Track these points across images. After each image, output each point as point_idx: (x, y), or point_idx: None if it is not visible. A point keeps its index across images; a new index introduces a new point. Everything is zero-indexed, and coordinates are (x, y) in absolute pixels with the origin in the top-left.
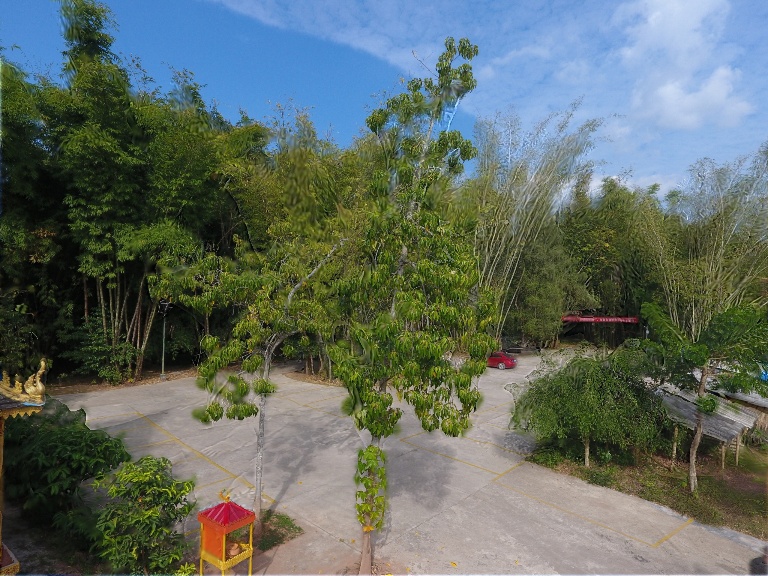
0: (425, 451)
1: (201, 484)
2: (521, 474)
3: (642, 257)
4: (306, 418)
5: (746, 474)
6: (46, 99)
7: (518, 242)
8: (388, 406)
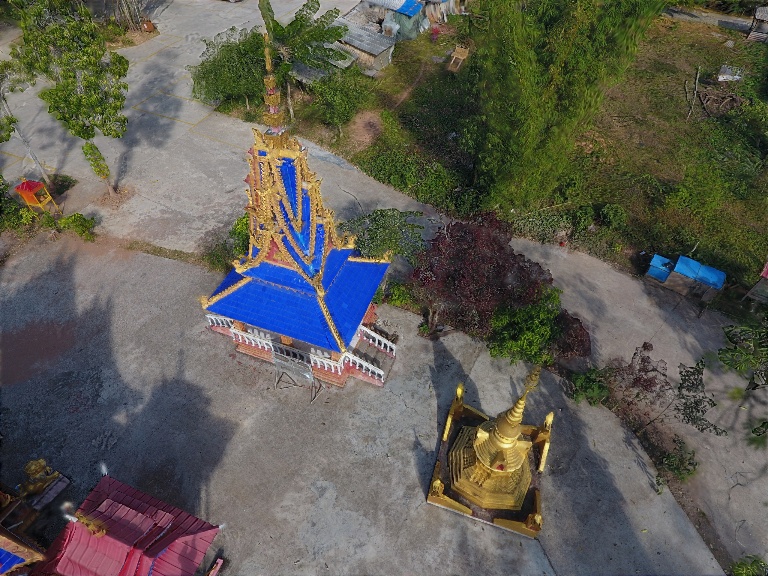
0: (150, 114)
1: (2, 168)
2: (207, 122)
3: None
4: None
5: None
6: None
7: None
8: (84, 127)
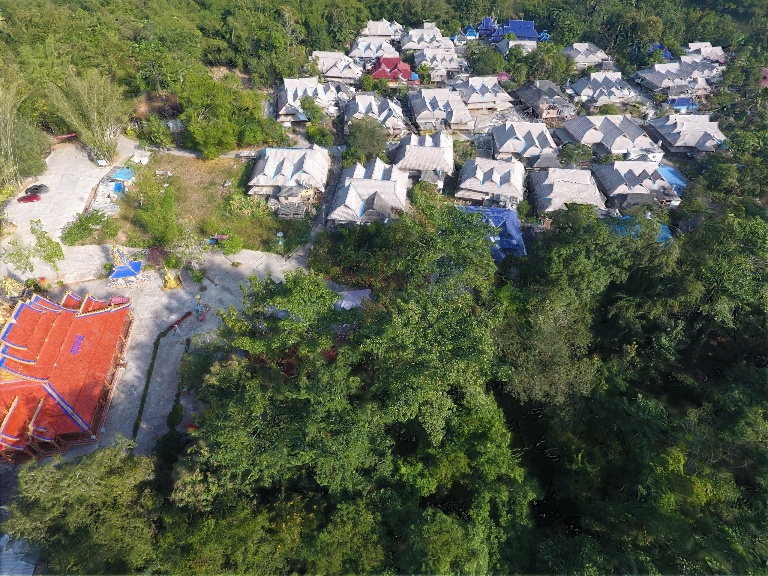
0: None
1: None
2: (69, 250)
3: (65, 120)
4: None
5: None
6: None
7: (8, 143)
8: None
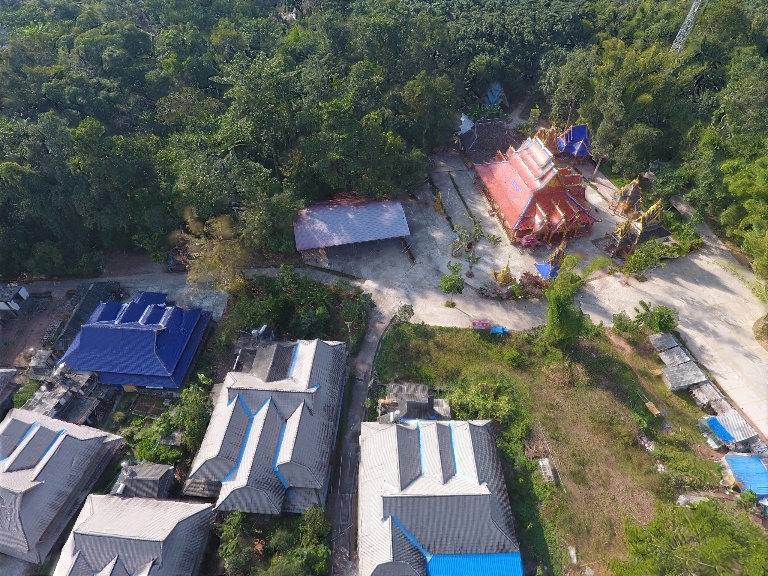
0: None
1: None
2: None
3: None
4: (705, 299)
5: None
6: (763, 185)
7: None
8: None
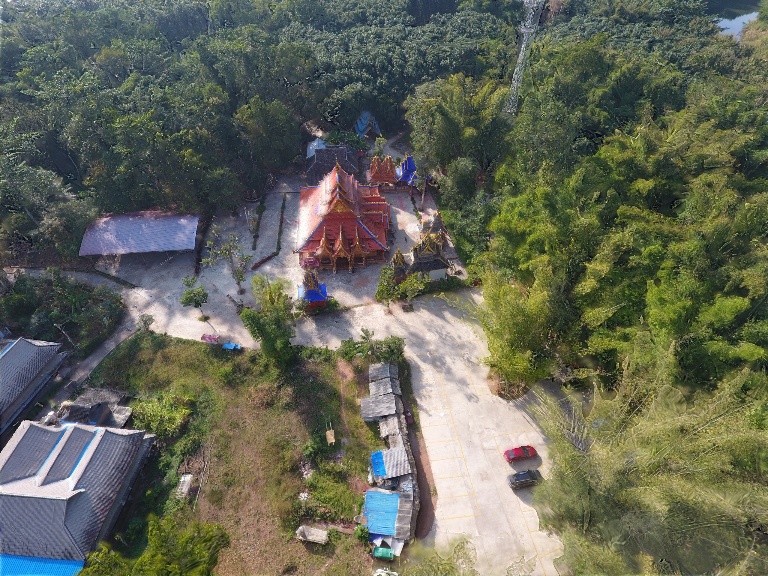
0: None
1: None
2: None
3: None
4: (460, 334)
5: (368, 381)
6: None
7: None
8: None
